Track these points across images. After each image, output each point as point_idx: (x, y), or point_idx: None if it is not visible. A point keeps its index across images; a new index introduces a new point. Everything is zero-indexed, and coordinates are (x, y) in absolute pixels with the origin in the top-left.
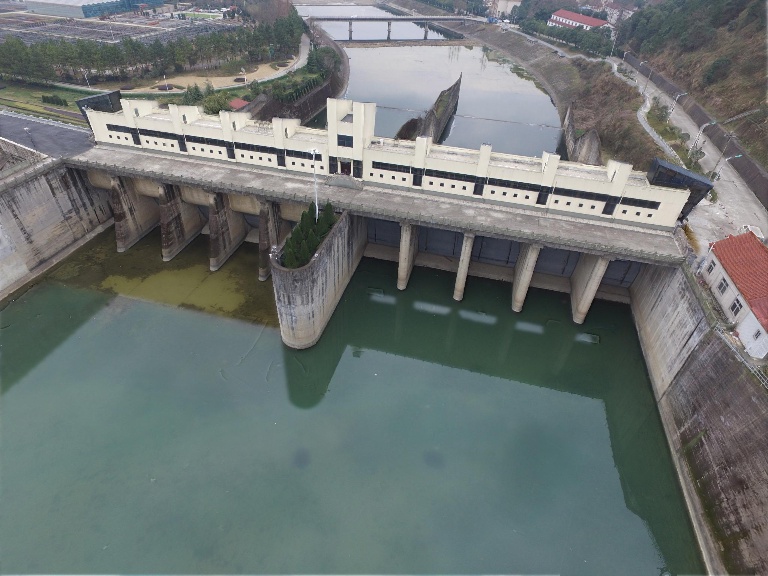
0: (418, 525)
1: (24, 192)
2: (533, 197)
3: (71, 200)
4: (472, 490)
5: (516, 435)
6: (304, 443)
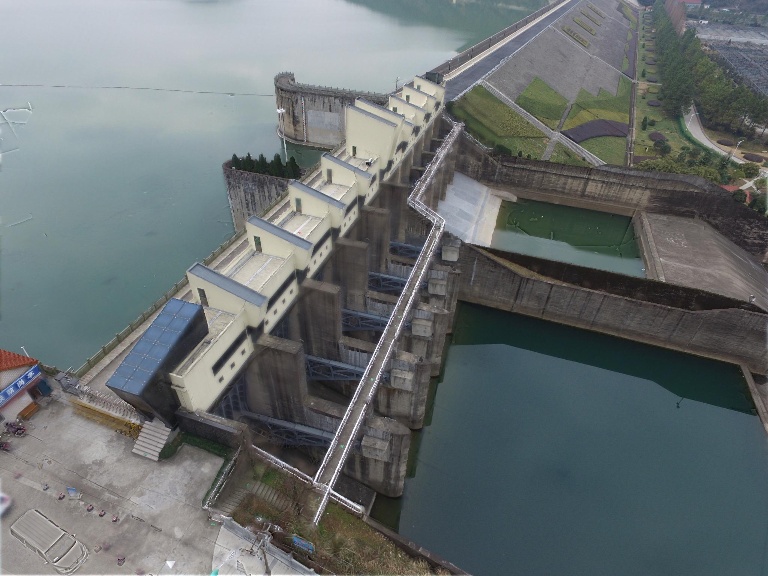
0: (76, 270)
1: None
2: None
3: None
4: (76, 293)
5: (95, 322)
6: (160, 235)
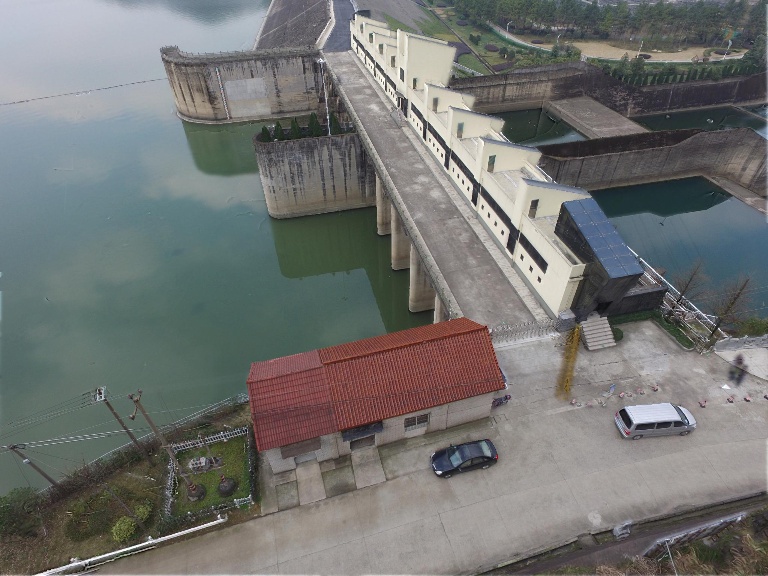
0: (141, 316)
1: (285, 63)
2: (471, 191)
3: (316, 81)
4: (176, 334)
5: (240, 347)
6: (191, 249)
